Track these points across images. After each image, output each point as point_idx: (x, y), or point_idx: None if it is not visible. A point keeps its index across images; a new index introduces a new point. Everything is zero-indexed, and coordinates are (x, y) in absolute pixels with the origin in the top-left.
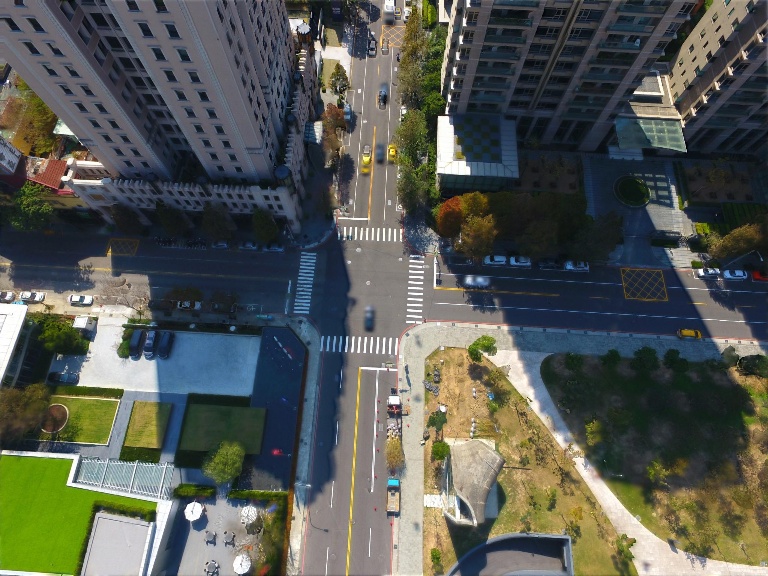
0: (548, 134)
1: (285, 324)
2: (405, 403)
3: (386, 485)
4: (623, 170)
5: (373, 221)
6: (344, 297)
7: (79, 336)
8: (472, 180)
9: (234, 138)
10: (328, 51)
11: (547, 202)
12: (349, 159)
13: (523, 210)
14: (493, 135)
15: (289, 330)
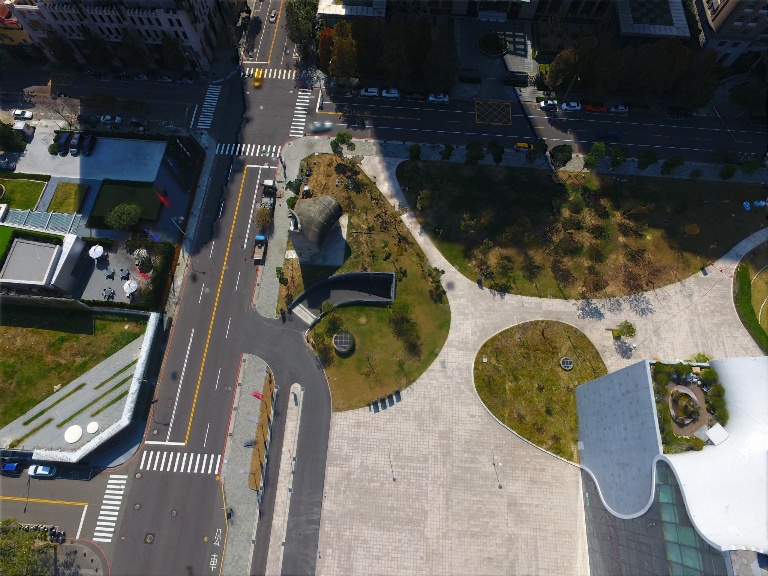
0: None
1: (189, 135)
2: (280, 190)
3: (254, 240)
4: (488, 29)
5: (272, 64)
6: (240, 117)
7: (19, 139)
8: None
9: None
10: None
11: (397, 25)
12: (258, 20)
13: (380, 35)
14: None
15: (191, 137)
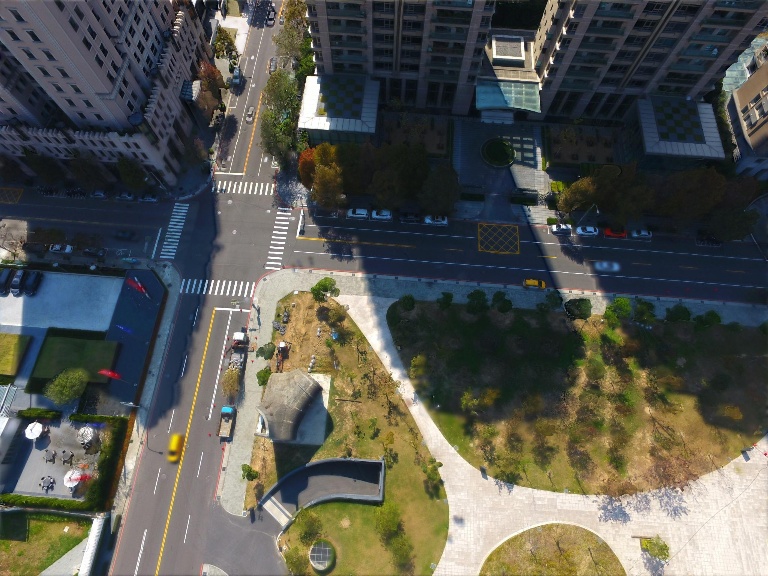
0: (420, 97)
1: (150, 267)
2: (252, 341)
3: (220, 412)
4: (492, 133)
5: (247, 176)
6: (210, 244)
7: None
8: (336, 136)
9: (80, 82)
10: (228, 20)
11: (388, 152)
12: (233, 119)
13: (369, 160)
14: (357, 94)
15: (151, 272)
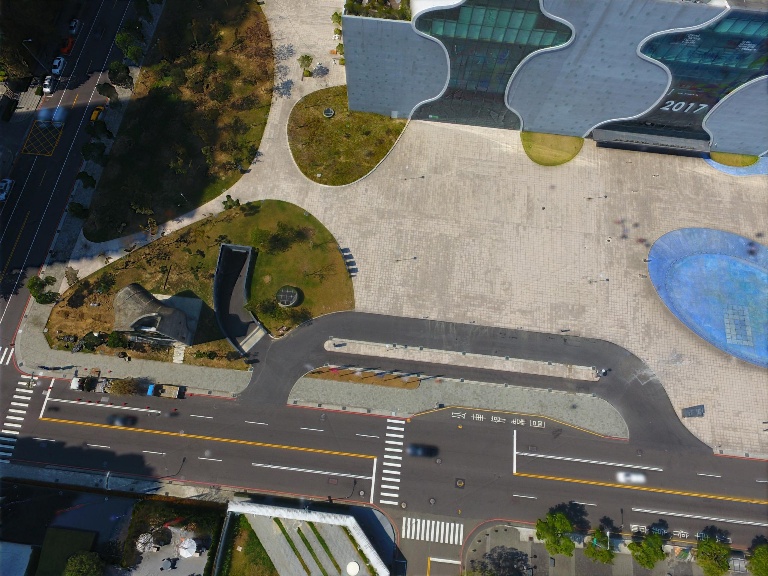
0: None
1: None
2: (88, 373)
3: None
4: None
5: None
6: None
7: None
8: None
9: None
10: None
11: None
12: None
13: None
14: None
15: None
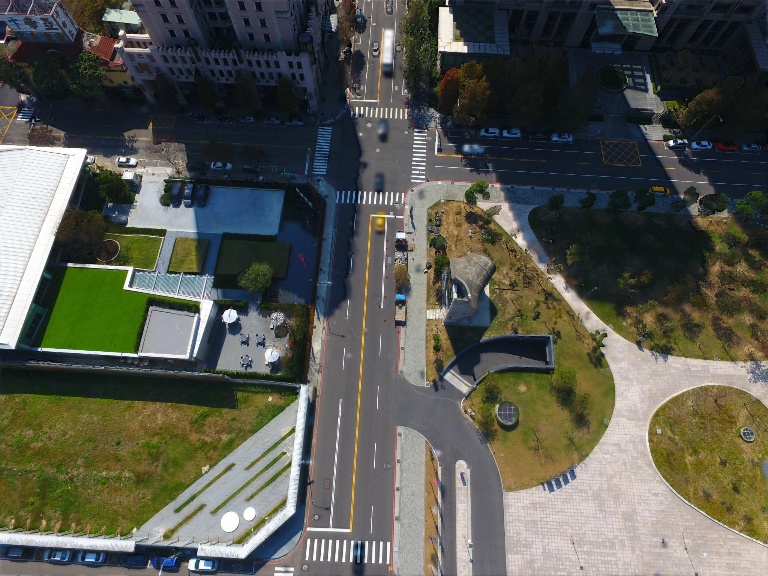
0: (537, 29)
1: (305, 182)
2: (410, 242)
3: (394, 299)
4: (604, 62)
5: (382, 102)
6: (357, 161)
7: (126, 189)
8: None
9: None
10: None
11: (533, 66)
12: (360, 54)
13: (513, 76)
14: (488, 22)
15: (309, 185)
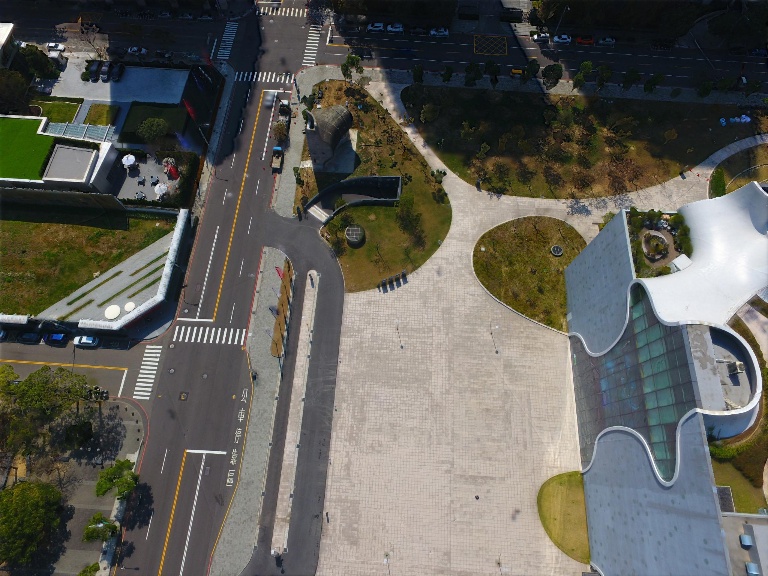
0: None
1: (209, 64)
2: (294, 110)
3: (272, 151)
4: None
5: (285, 4)
6: (256, 49)
7: (53, 68)
8: None
9: None
10: None
11: None
12: None
13: None
14: None
15: (211, 66)
